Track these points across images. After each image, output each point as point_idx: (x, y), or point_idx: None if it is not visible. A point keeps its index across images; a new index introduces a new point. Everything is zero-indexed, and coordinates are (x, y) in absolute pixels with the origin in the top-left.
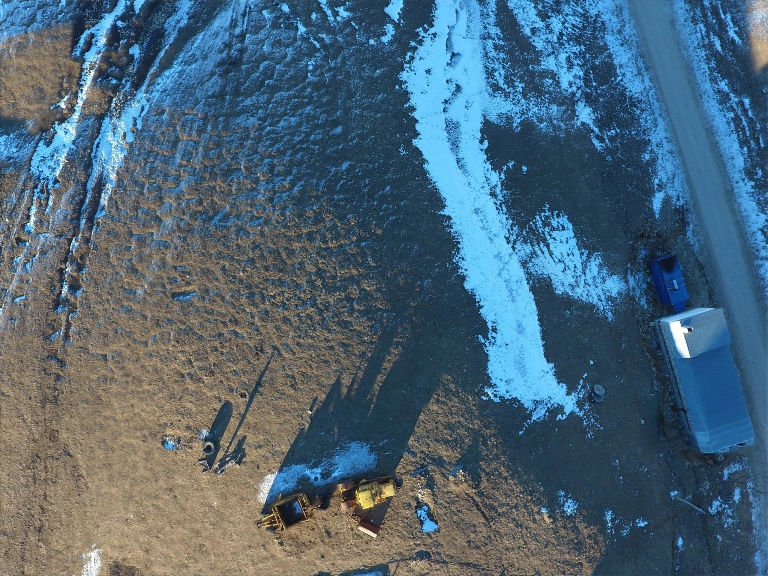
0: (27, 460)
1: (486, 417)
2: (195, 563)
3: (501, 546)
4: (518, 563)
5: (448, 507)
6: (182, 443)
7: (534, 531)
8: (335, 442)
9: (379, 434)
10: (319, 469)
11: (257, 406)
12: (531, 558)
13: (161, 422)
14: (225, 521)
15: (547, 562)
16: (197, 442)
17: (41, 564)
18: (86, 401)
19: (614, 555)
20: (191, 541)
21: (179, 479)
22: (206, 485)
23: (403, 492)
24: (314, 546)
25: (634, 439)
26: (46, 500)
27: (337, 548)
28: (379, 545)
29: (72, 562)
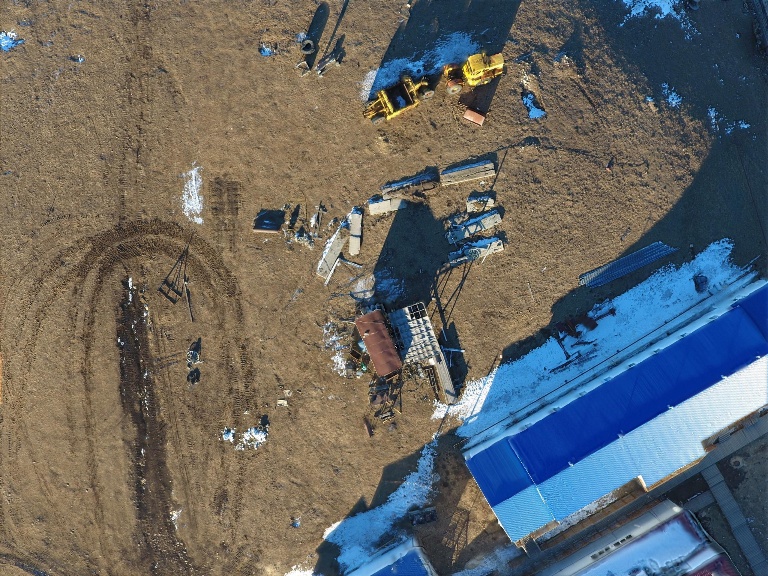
0: (121, 80)
1: (587, 7)
2: (298, 172)
3: (609, 133)
4: (626, 151)
5: (554, 92)
6: (279, 48)
7: (640, 119)
8: (436, 33)
9: (480, 23)
10: (421, 62)
11: (354, 4)
12: (639, 146)
13: (257, 29)
14: (327, 124)
15: (655, 151)
16: (295, 45)
17: (141, 186)
18: (179, 14)
19: (720, 151)
20: (293, 149)
21: (278, 85)
22: (306, 88)
23: (508, 79)
24: (420, 140)
25: (731, 49)
26: (143, 119)
27: (443, 140)
28: (486, 133)
29: (172, 182)
